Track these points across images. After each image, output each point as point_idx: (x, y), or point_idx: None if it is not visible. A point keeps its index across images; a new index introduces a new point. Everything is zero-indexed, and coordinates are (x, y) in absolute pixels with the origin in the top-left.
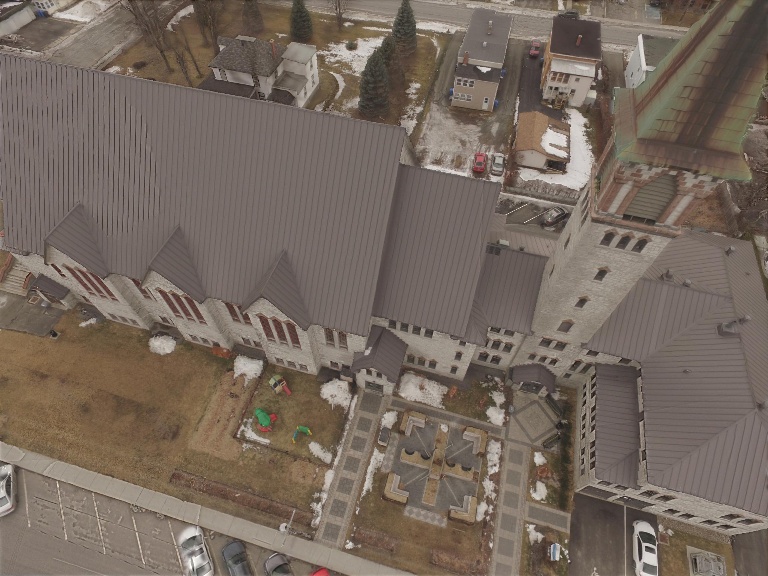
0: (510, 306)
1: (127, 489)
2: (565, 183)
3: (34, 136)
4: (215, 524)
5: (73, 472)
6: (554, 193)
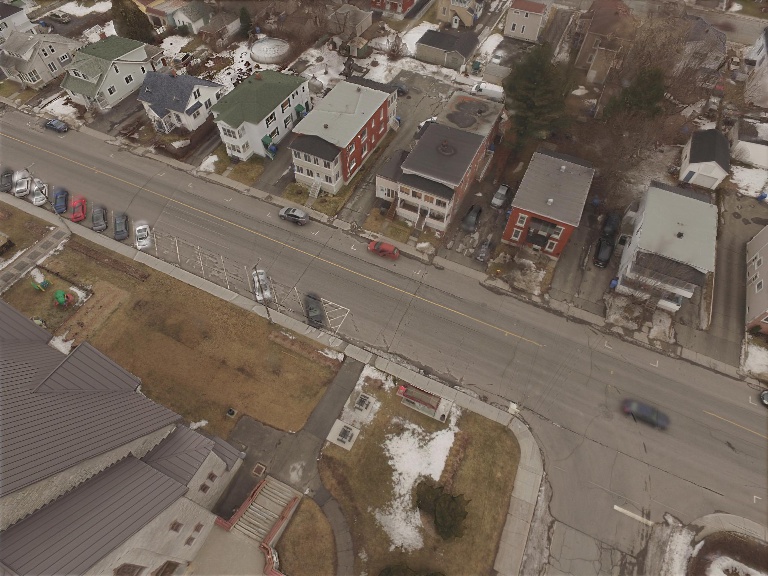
0: None
1: (180, 276)
2: None
3: (1, 448)
4: (128, 249)
5: (216, 292)
6: None
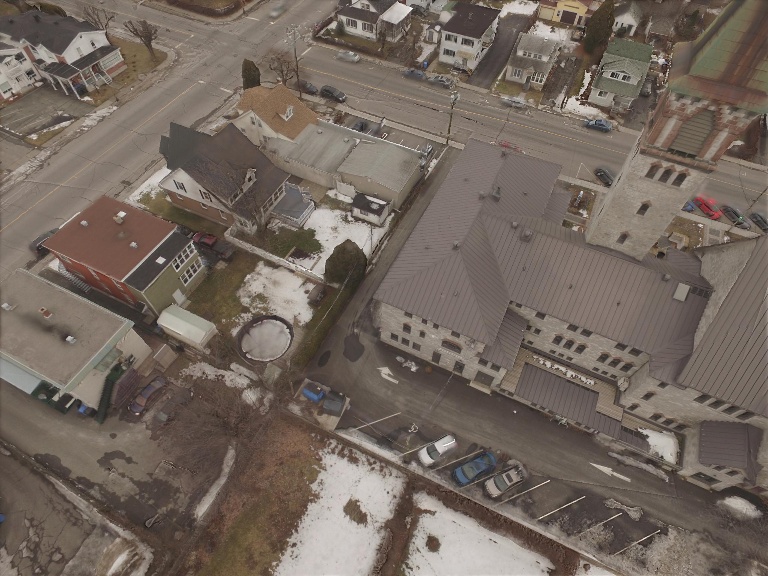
0: (655, 261)
1: None
2: (459, 570)
3: None
4: None
5: None
6: (504, 519)
